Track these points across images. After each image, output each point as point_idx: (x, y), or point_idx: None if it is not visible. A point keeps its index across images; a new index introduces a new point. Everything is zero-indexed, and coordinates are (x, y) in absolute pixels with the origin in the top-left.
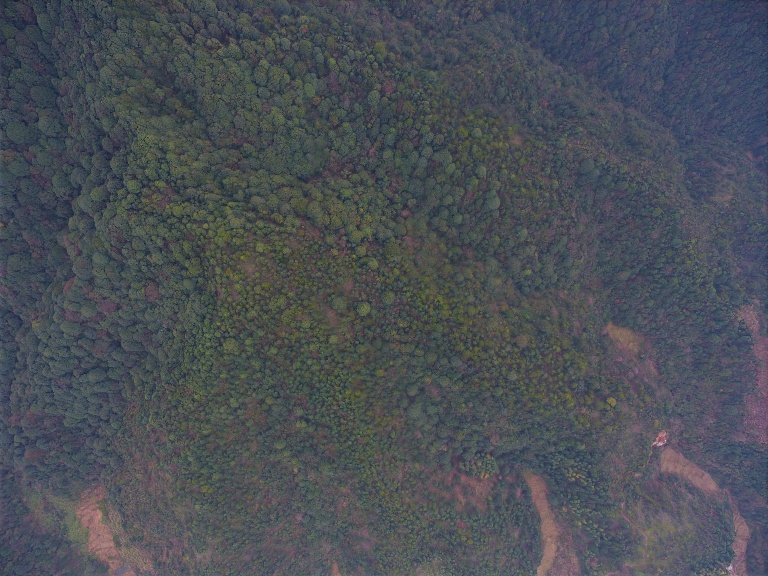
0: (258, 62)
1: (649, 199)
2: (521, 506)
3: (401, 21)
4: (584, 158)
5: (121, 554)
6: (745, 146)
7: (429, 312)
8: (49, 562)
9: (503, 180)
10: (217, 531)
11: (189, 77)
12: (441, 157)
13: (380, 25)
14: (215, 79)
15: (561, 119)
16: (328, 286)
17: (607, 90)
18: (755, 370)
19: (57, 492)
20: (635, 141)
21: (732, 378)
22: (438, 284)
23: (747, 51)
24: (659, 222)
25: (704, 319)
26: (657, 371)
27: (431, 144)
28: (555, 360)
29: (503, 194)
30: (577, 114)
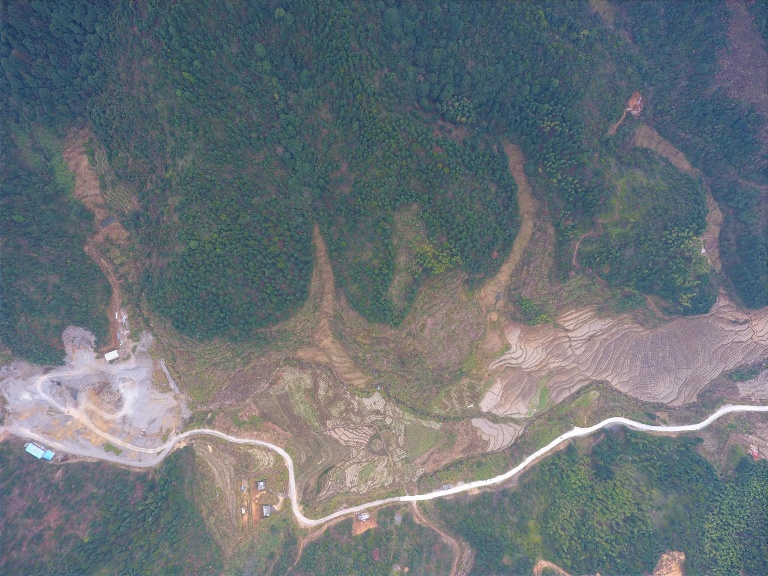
0: None
1: None
2: (497, 158)
3: None
4: None
5: (107, 199)
6: None
7: None
8: (36, 193)
9: None
10: (198, 127)
11: None
12: None
13: None
14: None
15: None
16: None
17: None
18: (726, 23)
19: (44, 117)
20: None
21: (704, 36)
22: None
23: None
24: None
25: None
26: (632, 42)
27: None
28: None
29: None
30: None
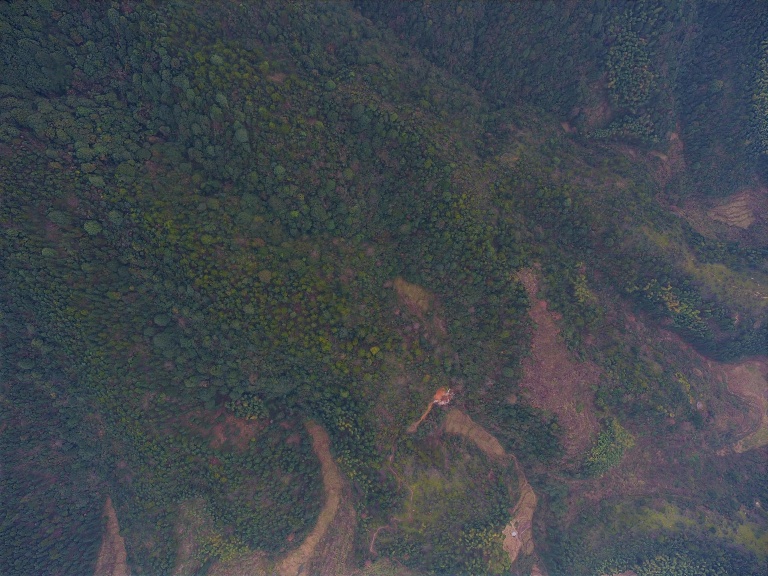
0: None
1: (421, 150)
2: (291, 452)
3: None
4: (354, 103)
5: None
6: (561, 117)
7: (156, 235)
8: None
9: (248, 112)
10: None
11: None
12: (178, 81)
13: None
14: None
15: (341, 64)
16: (45, 198)
17: (416, 47)
18: (531, 333)
19: None
20: (417, 93)
21: (511, 340)
22: (176, 210)
23: (545, 15)
24: (430, 174)
25: (484, 278)
26: (446, 330)
27: (170, 68)
28: (306, 300)
29: (252, 127)
30: (357, 61)
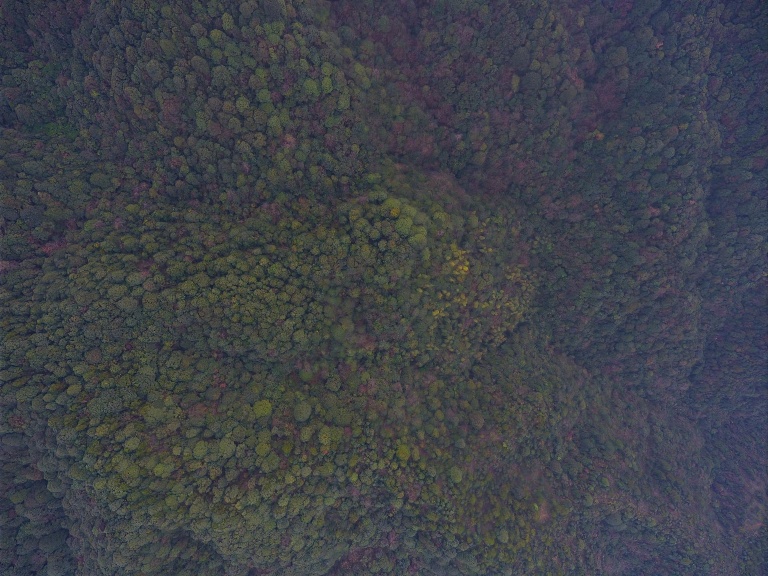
0: (277, 498)
1: (677, 547)
2: None
3: (423, 371)
4: (611, 513)
5: None
6: None
7: None
8: None
9: (529, 572)
10: None
11: (206, 540)
12: (466, 563)
13: (403, 402)
14: (233, 532)
15: (587, 461)
16: None
17: (632, 391)
18: None
19: None
20: (663, 479)
21: None
22: None
23: None
24: (687, 570)
25: None
26: None
27: None
28: None
29: None
30: (604, 457)
